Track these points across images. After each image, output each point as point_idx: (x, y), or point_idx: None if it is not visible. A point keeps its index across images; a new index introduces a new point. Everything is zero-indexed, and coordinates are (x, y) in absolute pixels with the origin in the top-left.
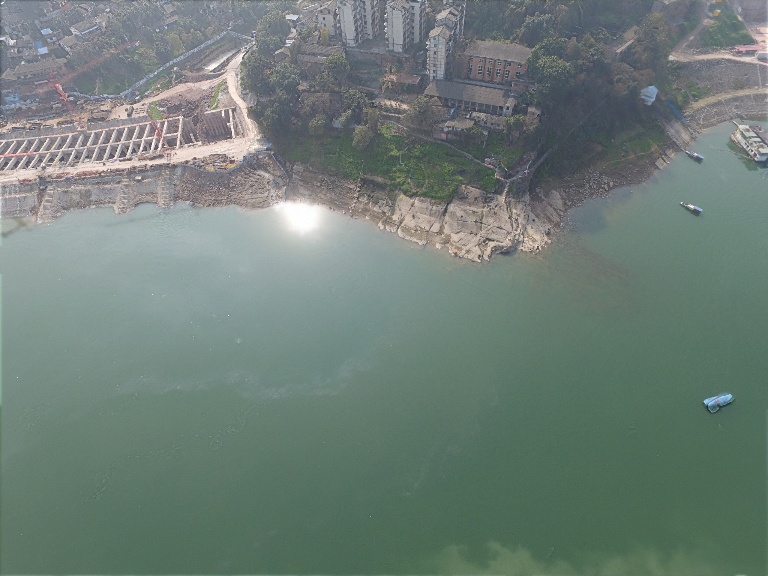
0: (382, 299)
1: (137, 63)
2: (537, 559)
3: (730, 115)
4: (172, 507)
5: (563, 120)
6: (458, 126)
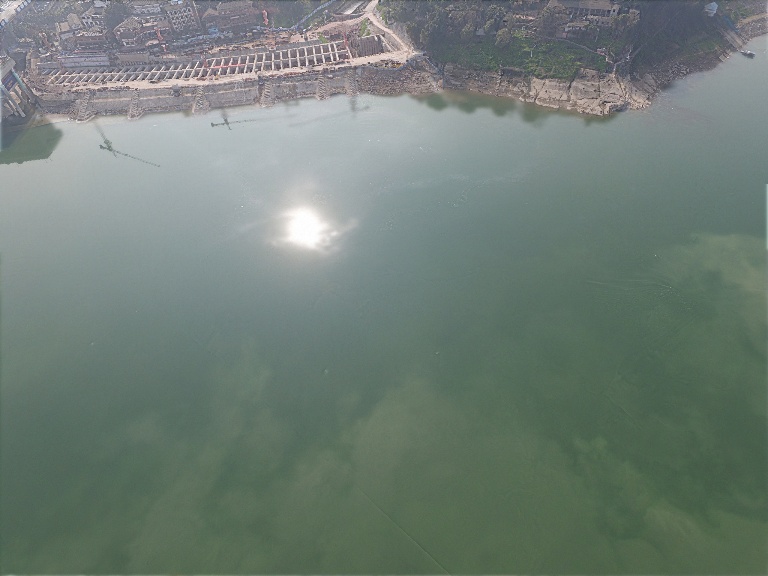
0: (538, 136)
1: (302, 4)
2: (686, 243)
3: None
4: (436, 236)
5: (650, 24)
6: (578, 25)
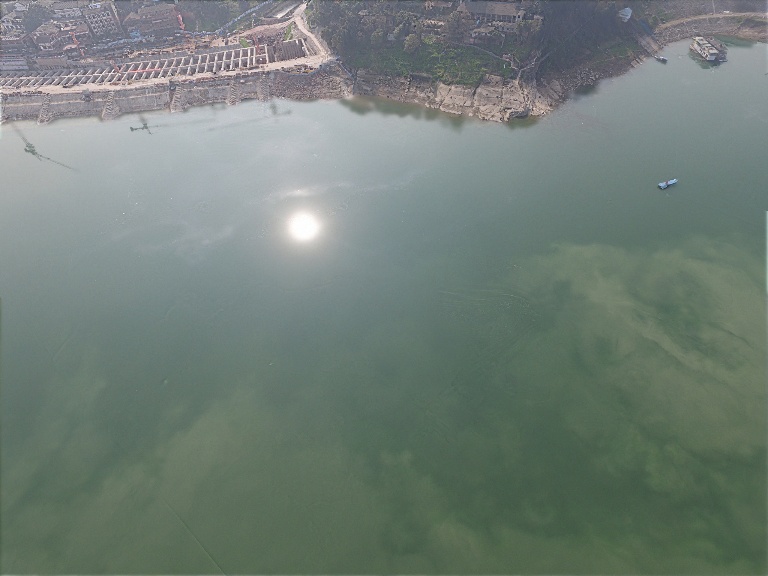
0: (433, 143)
1: (227, 8)
2: (547, 253)
3: (690, 33)
4: (308, 245)
5: (560, 30)
6: (483, 31)
